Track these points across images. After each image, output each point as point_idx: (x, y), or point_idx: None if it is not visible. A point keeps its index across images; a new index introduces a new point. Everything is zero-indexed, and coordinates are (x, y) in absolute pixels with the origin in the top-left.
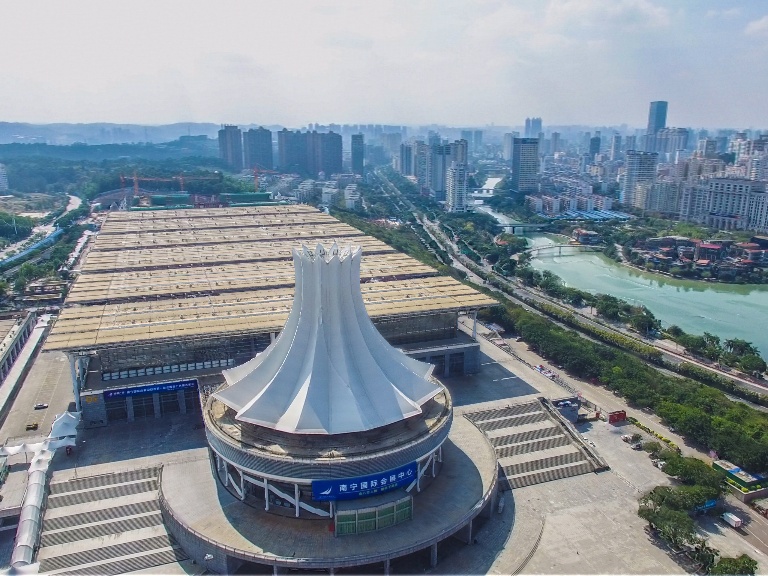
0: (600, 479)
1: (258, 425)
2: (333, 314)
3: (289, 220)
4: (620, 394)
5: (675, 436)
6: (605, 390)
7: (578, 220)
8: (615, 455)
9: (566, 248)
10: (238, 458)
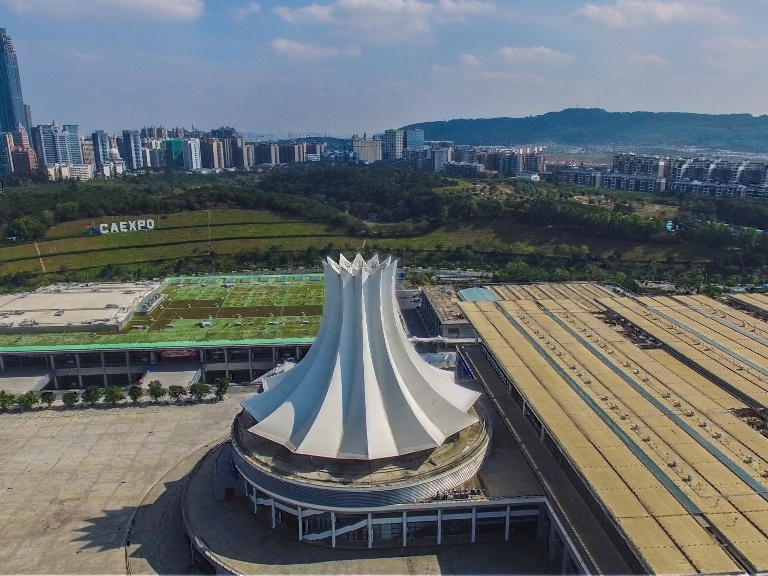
0: None
1: None
2: None
3: None
4: None
5: None
6: None
7: None
8: None
9: None
10: None
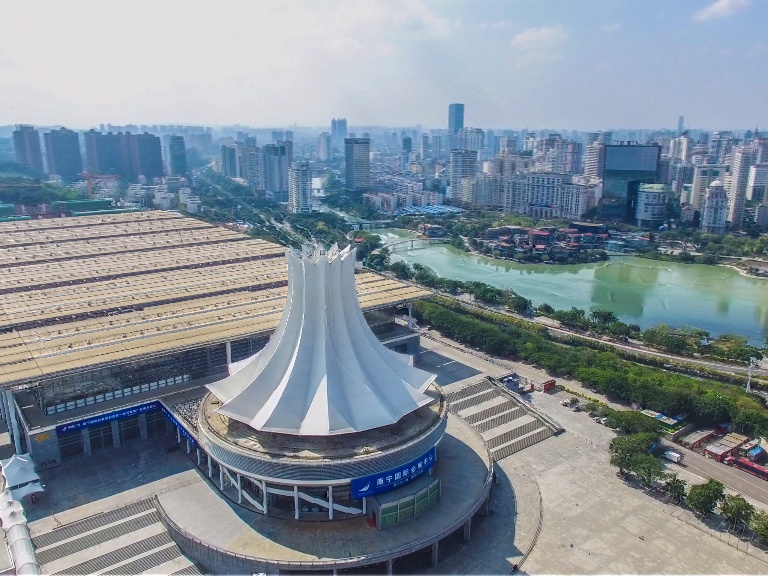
0: (562, 440)
1: (283, 433)
2: (337, 314)
3: (158, 227)
4: (539, 366)
5: (599, 396)
6: (525, 365)
7: (418, 215)
8: (563, 419)
9: (417, 242)
10: (267, 470)
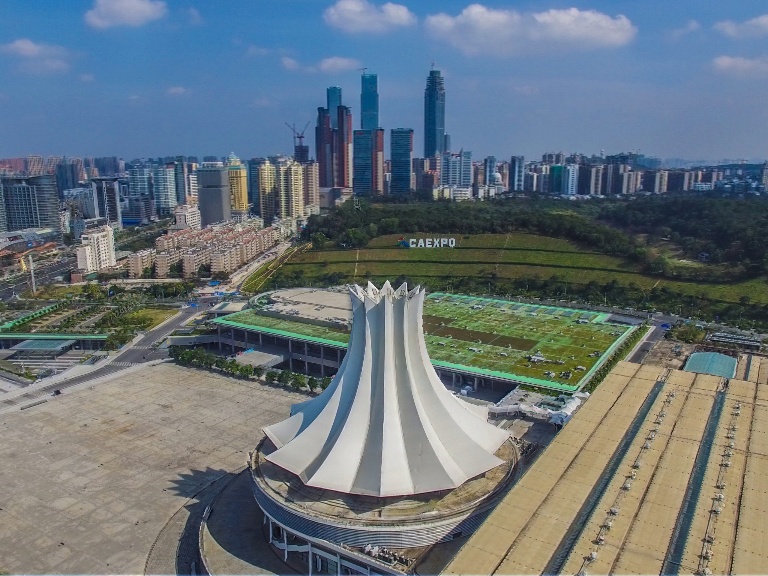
0: None
1: None
2: None
3: None
4: None
5: None
6: None
7: None
8: None
9: None
10: None
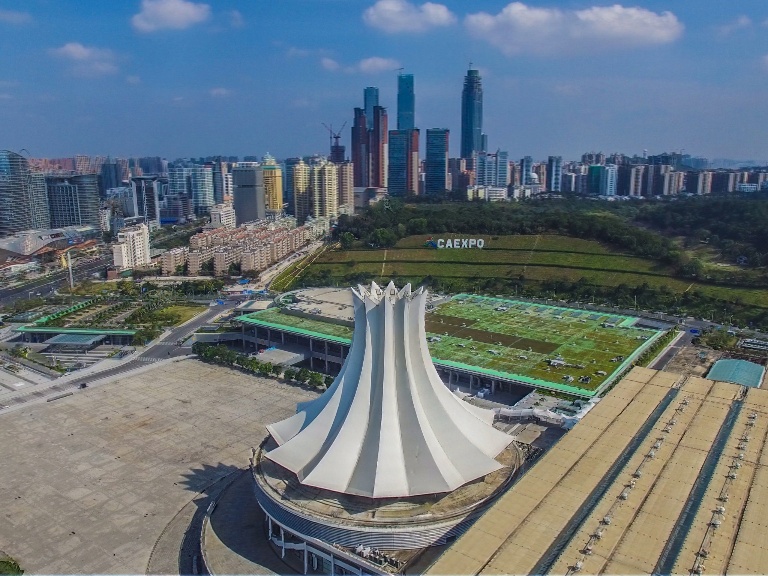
0: None
1: None
2: None
3: None
4: None
5: None
6: None
7: None
8: None
9: None
10: None
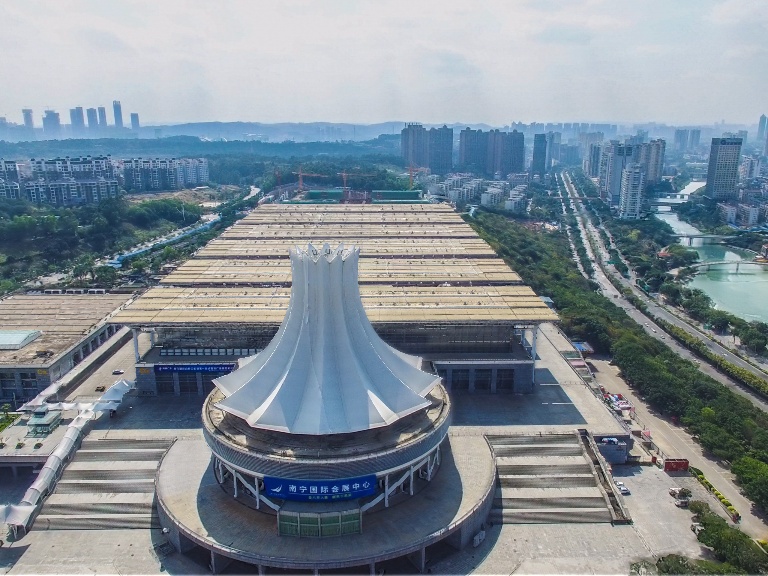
0: (613, 532)
1: (232, 414)
2: (319, 314)
3: (414, 219)
4: None
5: (743, 500)
6: (684, 432)
7: None
8: (649, 508)
9: (745, 265)
10: (211, 442)
